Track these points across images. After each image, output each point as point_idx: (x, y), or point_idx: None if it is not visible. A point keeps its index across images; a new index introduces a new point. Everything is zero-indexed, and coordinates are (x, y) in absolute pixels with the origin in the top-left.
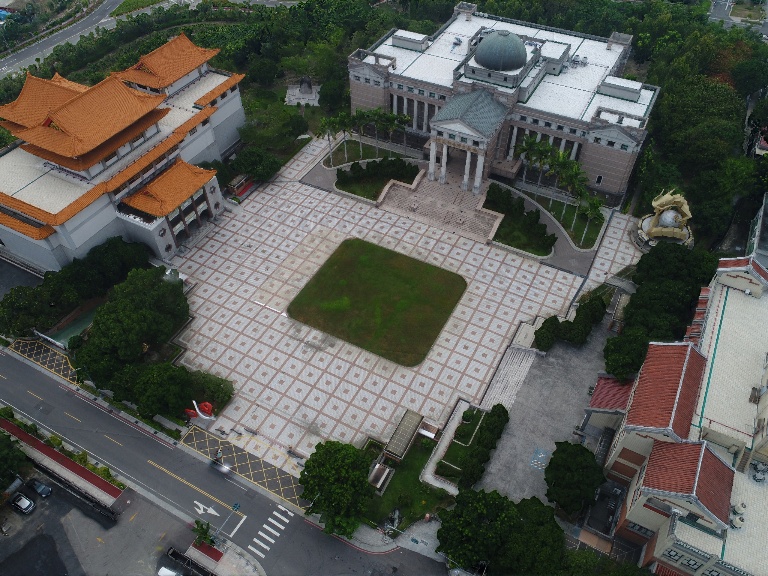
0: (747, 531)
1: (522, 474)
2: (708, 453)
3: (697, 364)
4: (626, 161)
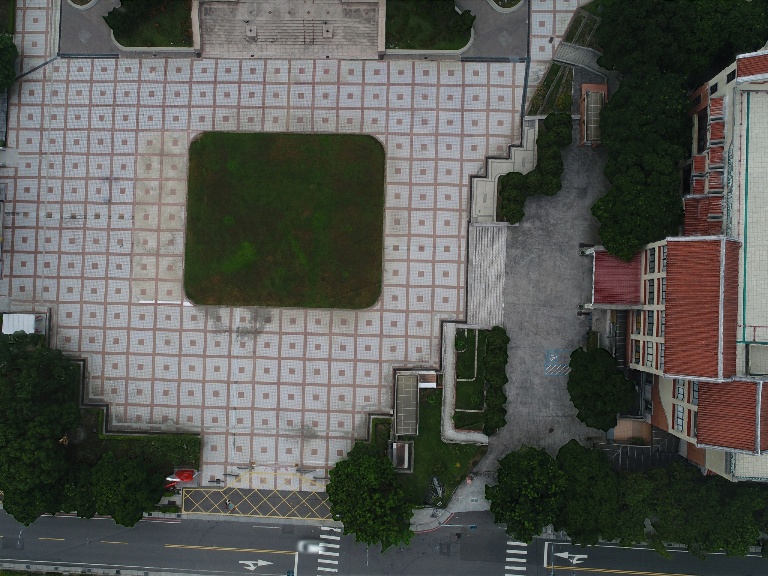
0: None
1: (541, 389)
2: (762, 386)
3: (732, 258)
4: None
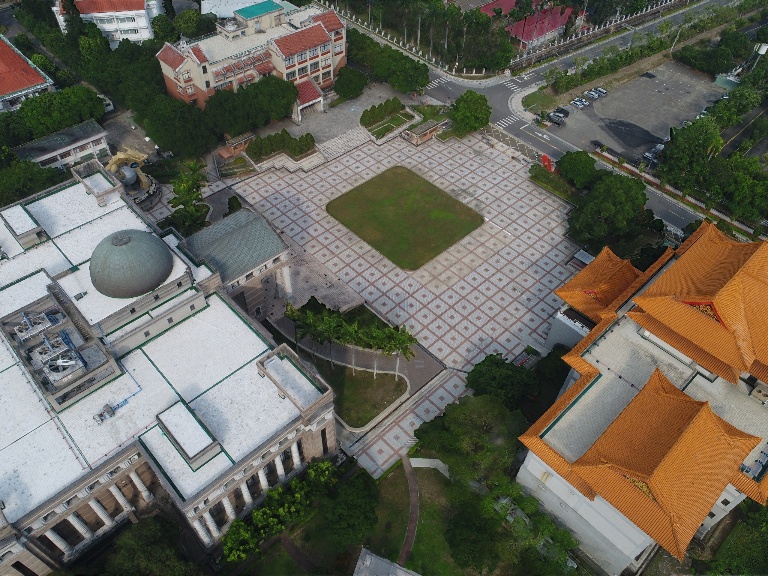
0: None
1: (369, 106)
2: None
3: None
4: None
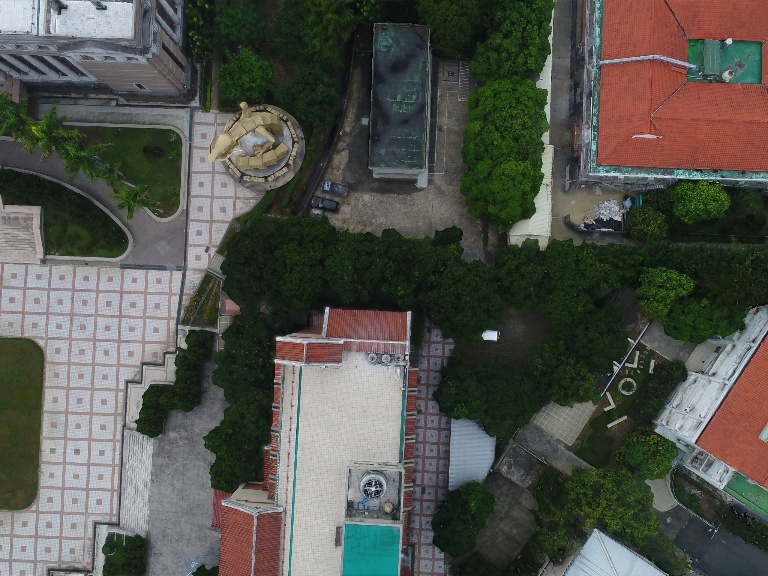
0: None
1: None
2: None
3: (271, 529)
4: (151, 69)
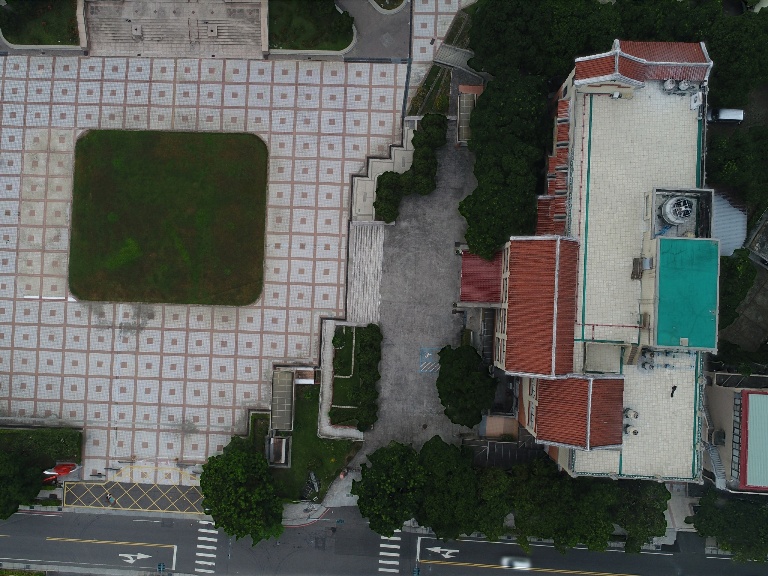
0: (641, 430)
1: (415, 386)
2: (596, 383)
3: (569, 258)
4: None
